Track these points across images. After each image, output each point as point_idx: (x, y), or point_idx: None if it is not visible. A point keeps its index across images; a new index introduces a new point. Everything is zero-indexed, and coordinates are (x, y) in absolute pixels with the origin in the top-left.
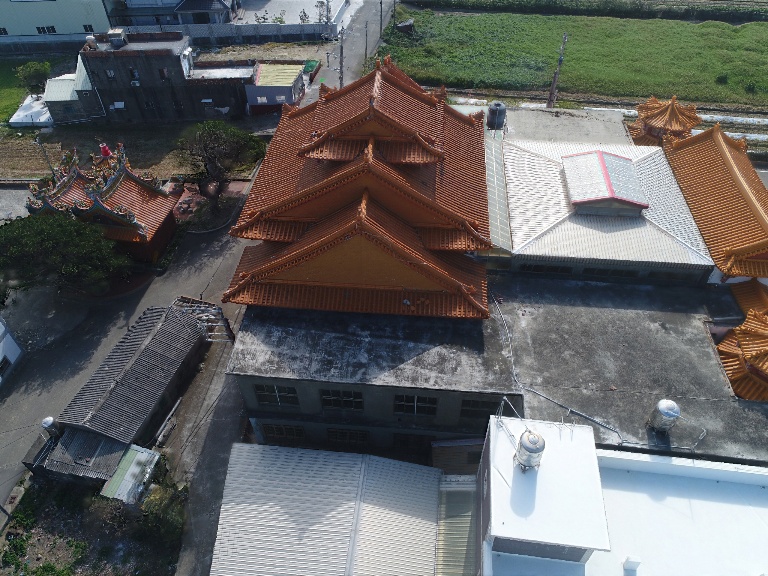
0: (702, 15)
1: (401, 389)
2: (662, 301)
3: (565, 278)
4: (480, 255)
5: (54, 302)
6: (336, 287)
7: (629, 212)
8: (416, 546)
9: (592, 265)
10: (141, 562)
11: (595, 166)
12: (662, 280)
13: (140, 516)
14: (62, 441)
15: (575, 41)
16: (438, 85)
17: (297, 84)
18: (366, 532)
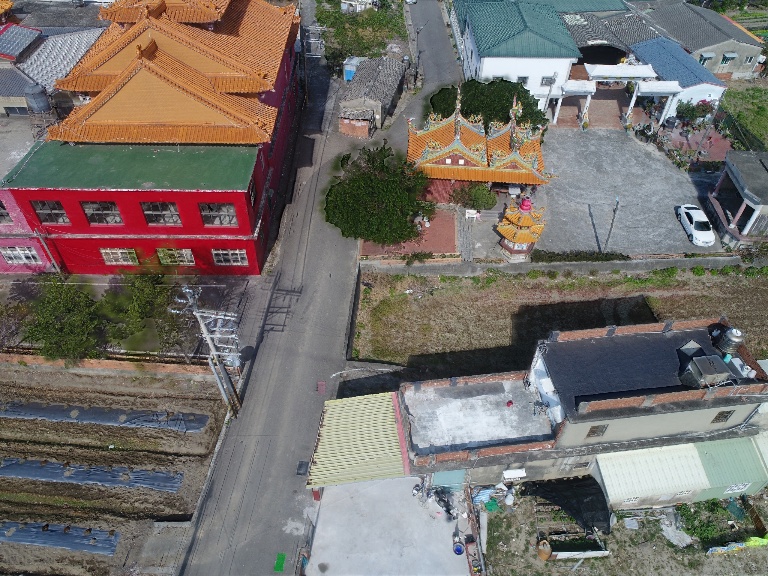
0: None
1: None
2: None
3: None
4: None
5: None
6: None
7: None
8: None
9: None
10: None
11: None
12: None
13: None
14: None
15: None
16: None
17: None
18: None
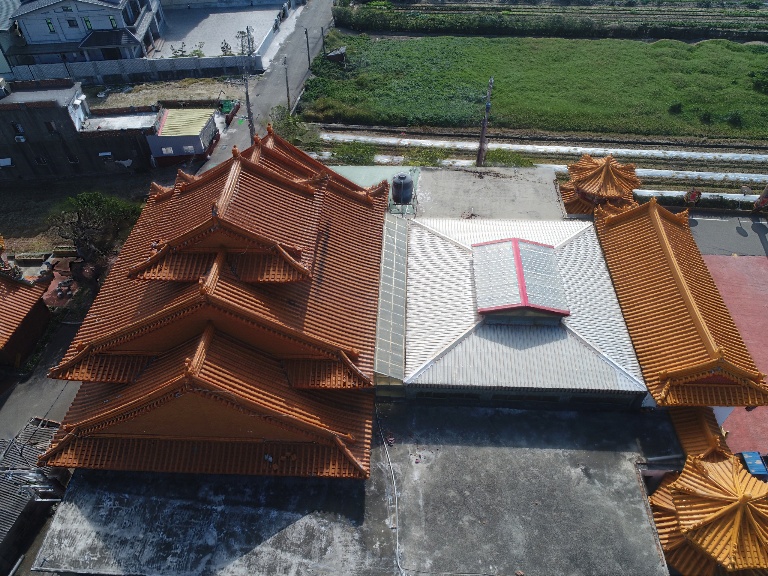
0: (656, 33)
1: None
2: (587, 434)
3: (472, 405)
4: None
5: None
6: (182, 440)
7: (547, 320)
8: None
9: (502, 392)
10: None
11: (508, 260)
12: (588, 404)
13: None
14: None
15: (520, 67)
16: (369, 123)
17: (207, 131)
18: None
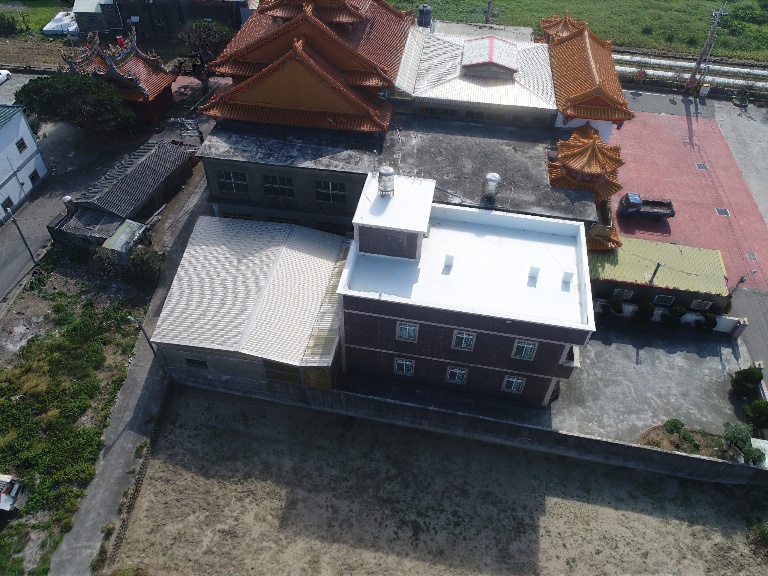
0: None
1: (319, 174)
2: (519, 136)
3: (452, 120)
4: (390, 97)
5: (74, 147)
6: (280, 108)
7: (504, 75)
8: (318, 272)
9: (471, 108)
10: (128, 294)
11: (485, 45)
12: (523, 124)
13: (129, 264)
14: (76, 215)
15: None
16: None
17: None
18: (284, 262)
